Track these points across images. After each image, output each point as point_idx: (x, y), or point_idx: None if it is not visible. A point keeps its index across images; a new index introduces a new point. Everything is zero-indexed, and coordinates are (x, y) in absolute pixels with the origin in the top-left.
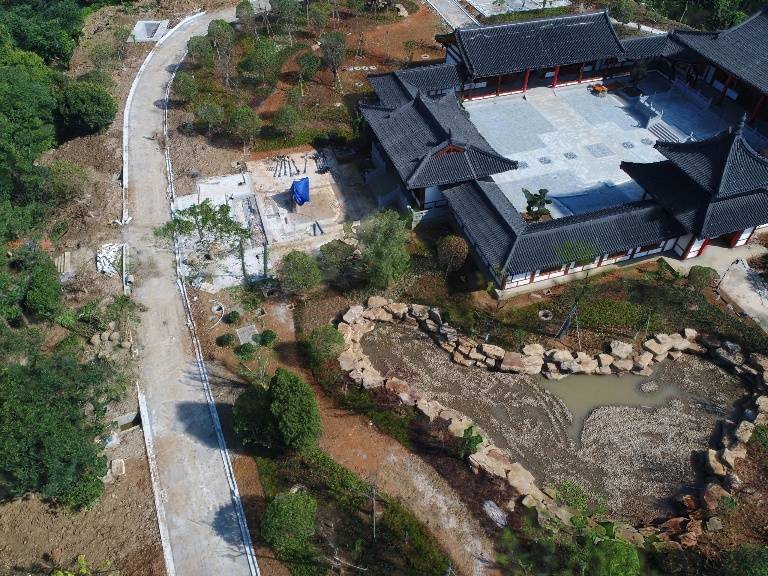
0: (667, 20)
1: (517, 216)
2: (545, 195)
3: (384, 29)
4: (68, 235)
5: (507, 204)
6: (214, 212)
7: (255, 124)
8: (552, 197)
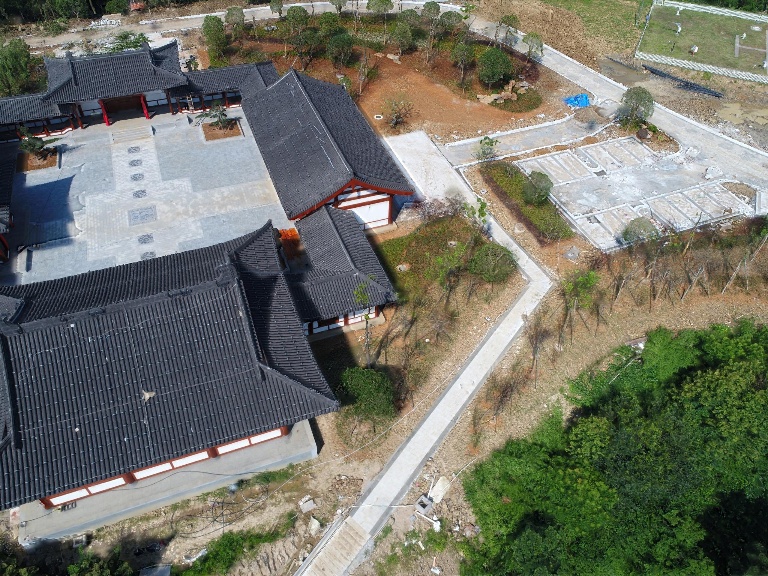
0: (552, 359)
1: (6, 118)
2: (80, 171)
3: (436, 88)
4: (140, 13)
5: (24, 115)
6: (136, 44)
7: (206, 29)
8: (75, 174)
